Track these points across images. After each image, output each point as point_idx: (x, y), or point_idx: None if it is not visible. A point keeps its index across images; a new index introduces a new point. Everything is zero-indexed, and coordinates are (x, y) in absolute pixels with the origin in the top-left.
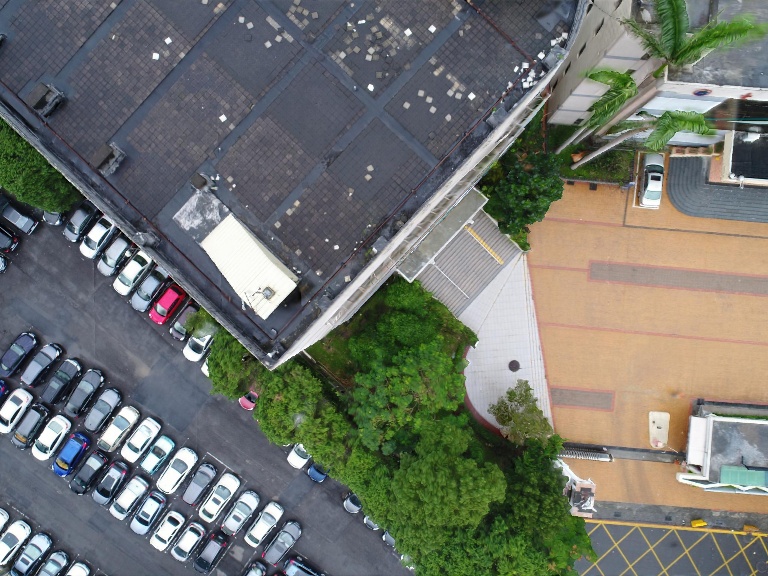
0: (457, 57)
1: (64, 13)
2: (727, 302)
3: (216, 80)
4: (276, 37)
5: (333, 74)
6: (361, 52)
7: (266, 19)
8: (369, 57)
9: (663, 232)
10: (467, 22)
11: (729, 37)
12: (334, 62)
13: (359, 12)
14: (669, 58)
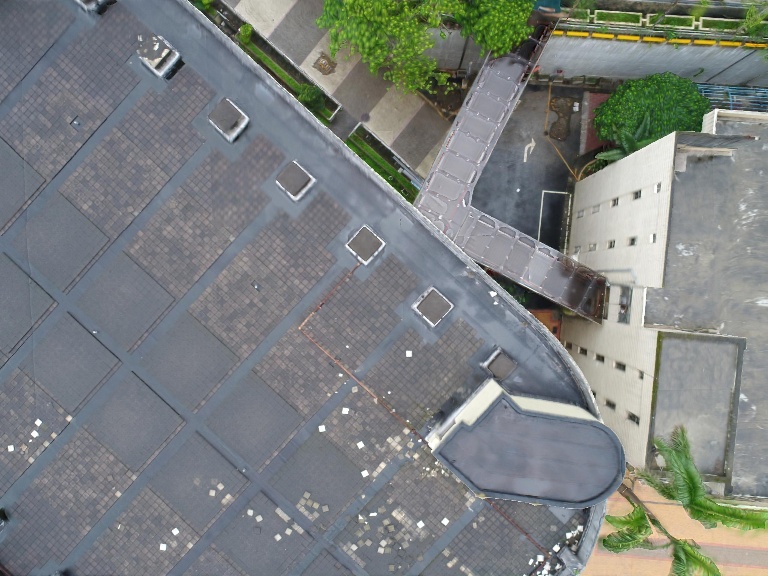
0: (471, 549)
1: (68, 501)
2: (734, 575)
3: (225, 571)
4: (286, 530)
5: (345, 565)
6: (373, 544)
7: (275, 511)
8: (381, 550)
9: (670, 507)
10: (481, 514)
11: (747, 526)
12: (345, 554)
13: (370, 504)
14: (684, 505)
